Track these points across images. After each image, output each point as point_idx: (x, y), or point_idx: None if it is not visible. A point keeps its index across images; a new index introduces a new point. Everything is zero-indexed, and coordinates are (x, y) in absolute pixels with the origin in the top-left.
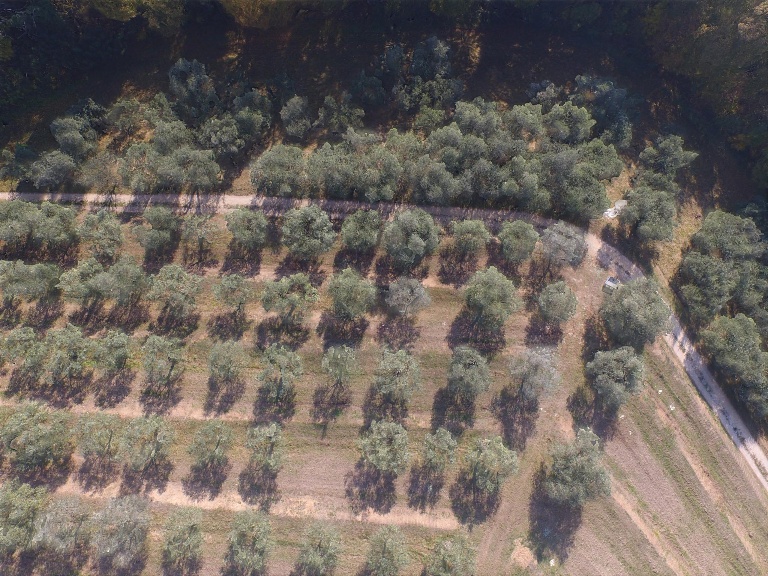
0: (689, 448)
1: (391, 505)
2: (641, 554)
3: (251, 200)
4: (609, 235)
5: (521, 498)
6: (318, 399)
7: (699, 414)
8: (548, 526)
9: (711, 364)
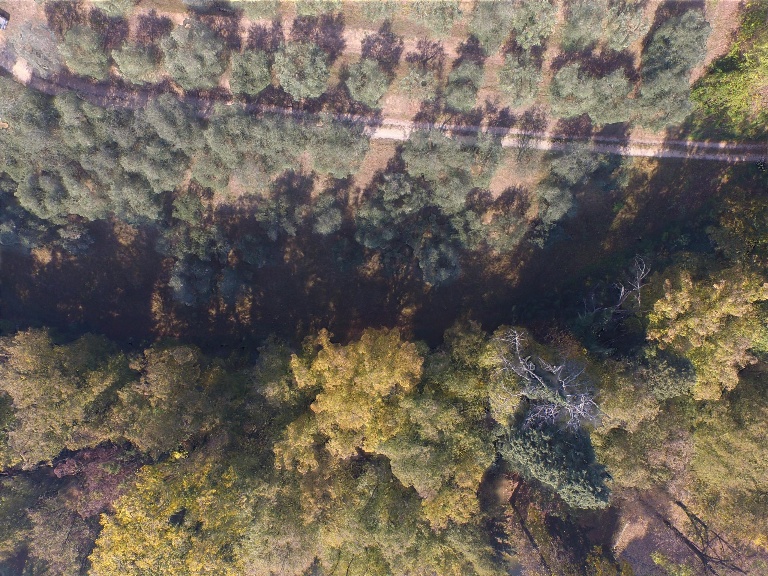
0: None
1: None
2: None
3: (376, 133)
4: None
5: None
6: None
7: None
8: None
9: None
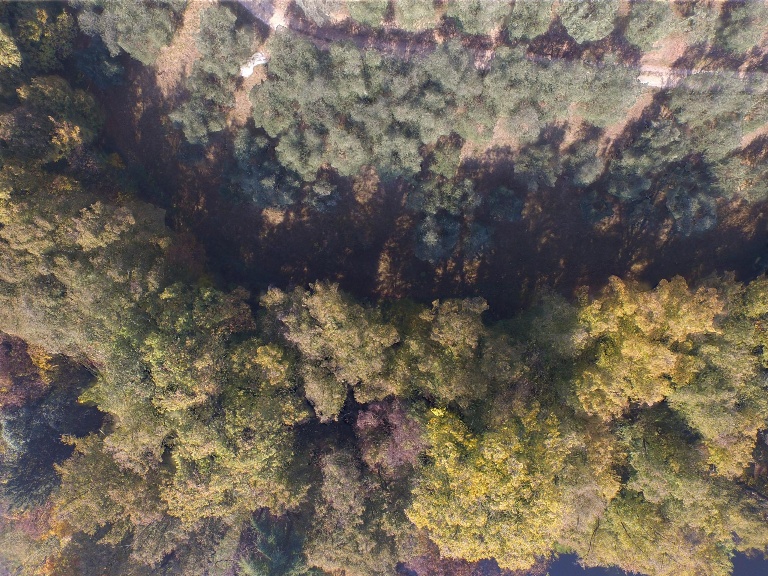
0: None
1: None
2: None
3: None
4: (262, 31)
5: None
6: None
7: None
8: None
9: None
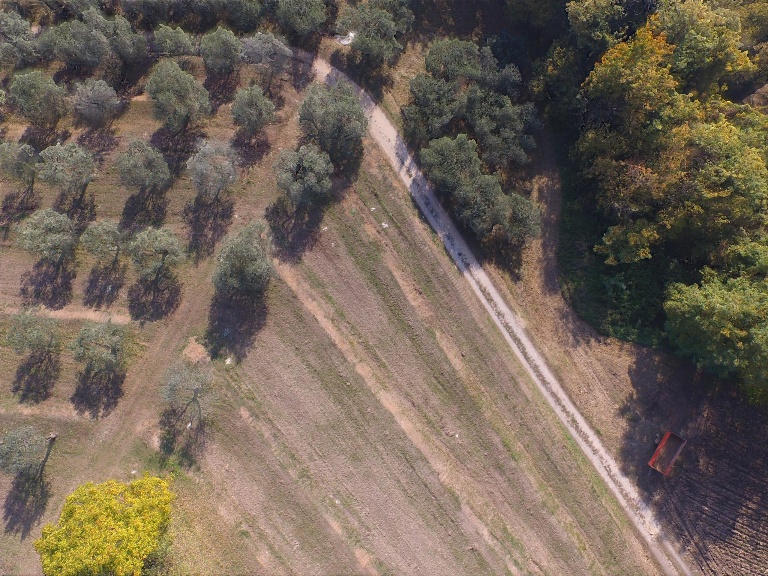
0: (400, 265)
1: (66, 303)
2: (327, 358)
3: None
4: (338, 60)
5: (203, 299)
6: (7, 205)
7: (414, 233)
8: (228, 327)
9: (438, 190)
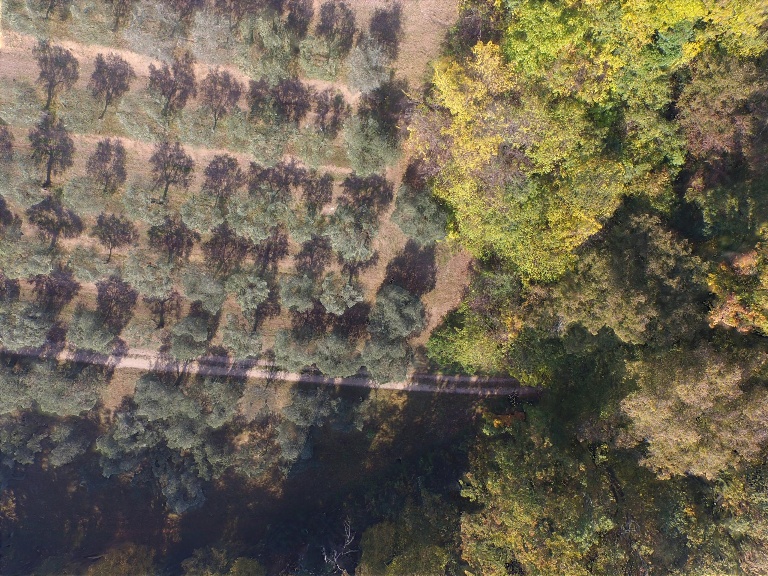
0: None
1: None
2: None
3: (121, 362)
4: None
5: None
6: (8, 150)
7: None
8: None
9: None
